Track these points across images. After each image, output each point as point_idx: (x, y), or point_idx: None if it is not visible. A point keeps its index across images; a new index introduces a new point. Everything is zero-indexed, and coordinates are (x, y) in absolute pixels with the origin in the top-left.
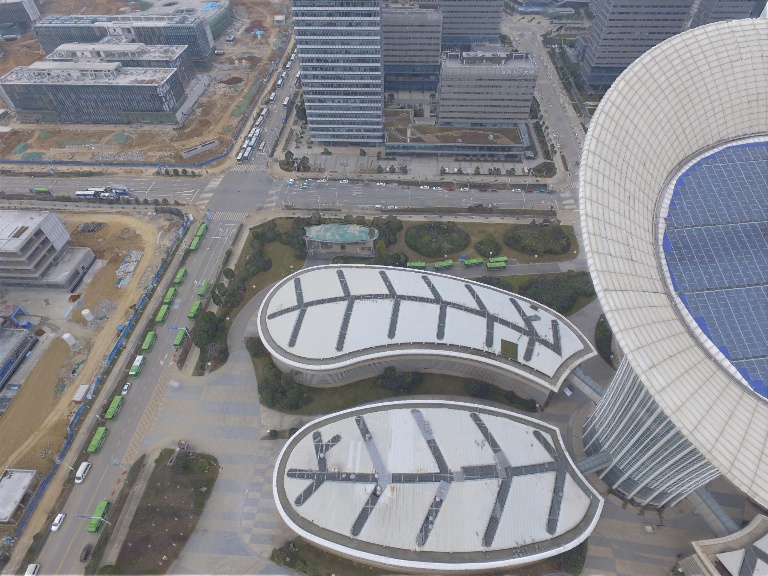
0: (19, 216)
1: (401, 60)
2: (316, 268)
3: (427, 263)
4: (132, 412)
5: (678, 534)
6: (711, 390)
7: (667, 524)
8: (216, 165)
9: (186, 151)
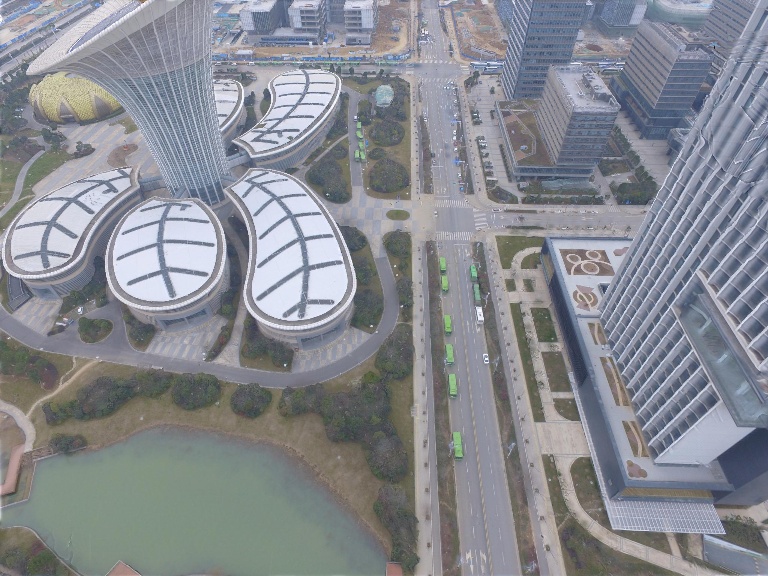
0: (369, 5)
1: (640, 85)
2: (338, 79)
3: (364, 133)
4: (276, 68)
5: (159, 194)
6: (115, 4)
7: (165, 191)
8: (465, 59)
9: (477, 47)
